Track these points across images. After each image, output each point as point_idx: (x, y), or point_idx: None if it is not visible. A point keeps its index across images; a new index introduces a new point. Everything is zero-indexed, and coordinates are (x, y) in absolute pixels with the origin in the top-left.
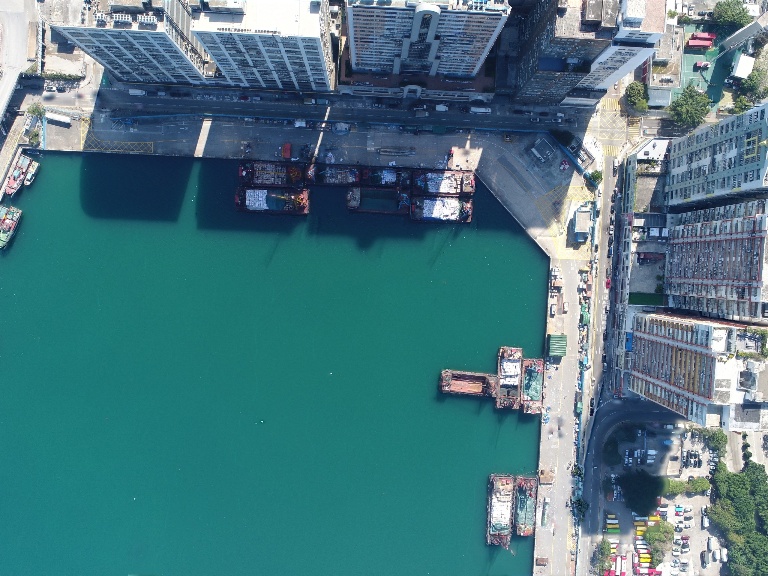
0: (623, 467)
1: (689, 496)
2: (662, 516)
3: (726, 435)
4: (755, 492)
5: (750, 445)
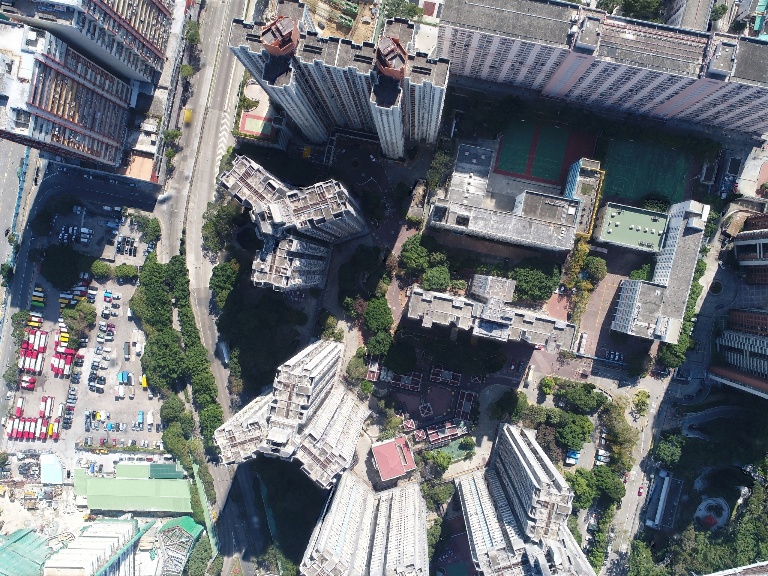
0: (59, 242)
1: (120, 283)
2: (89, 298)
3: (159, 224)
4: (174, 285)
5: (188, 242)
